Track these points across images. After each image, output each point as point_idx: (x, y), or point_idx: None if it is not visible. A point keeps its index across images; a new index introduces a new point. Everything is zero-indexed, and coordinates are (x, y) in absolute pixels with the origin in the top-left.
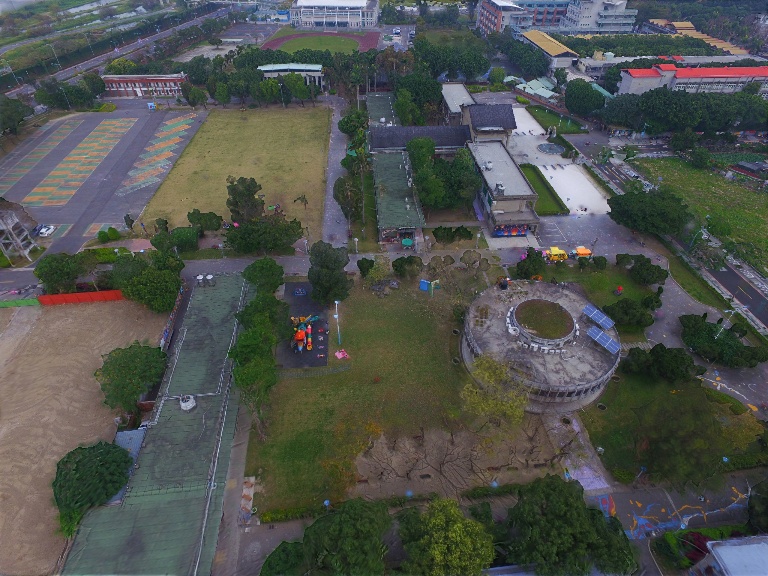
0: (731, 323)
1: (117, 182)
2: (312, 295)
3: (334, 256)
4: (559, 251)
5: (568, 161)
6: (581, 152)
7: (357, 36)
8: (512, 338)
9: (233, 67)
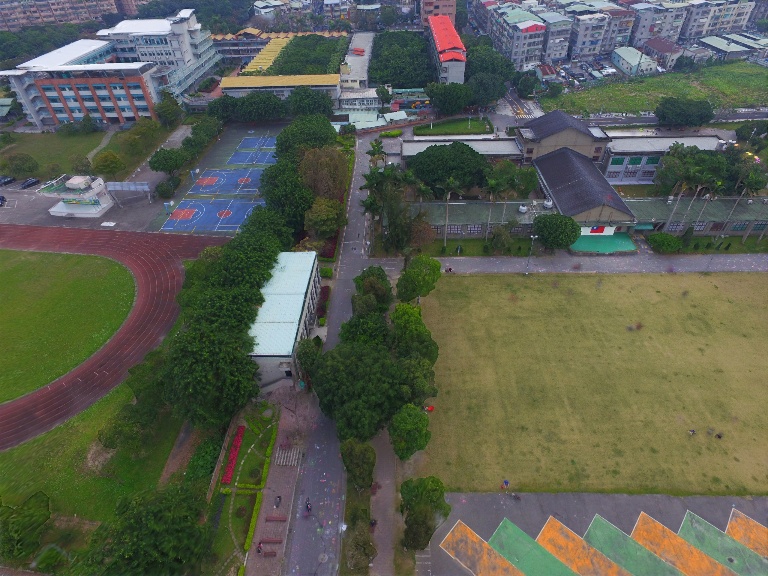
0: None
1: None
2: None
3: None
4: (750, 153)
5: None
6: None
7: None
8: None
9: None
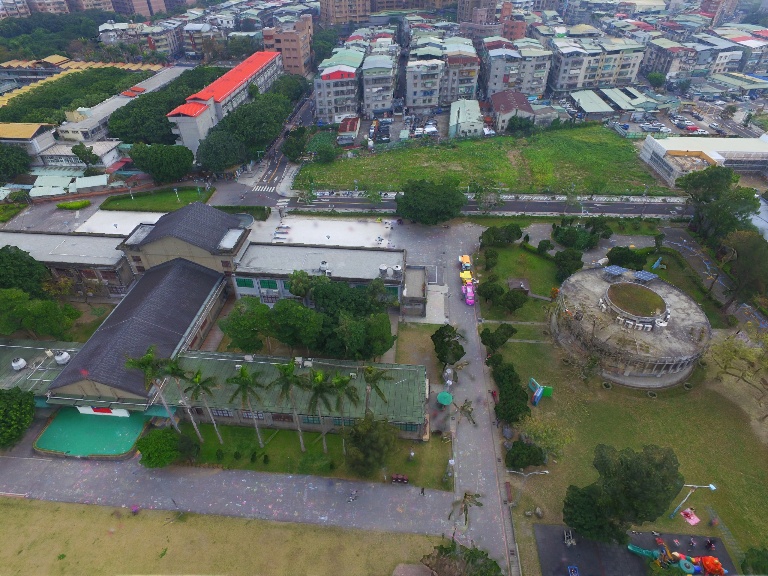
0: (549, 224)
1: None
2: None
3: None
4: (467, 273)
5: (274, 220)
6: None
7: None
8: None
9: None
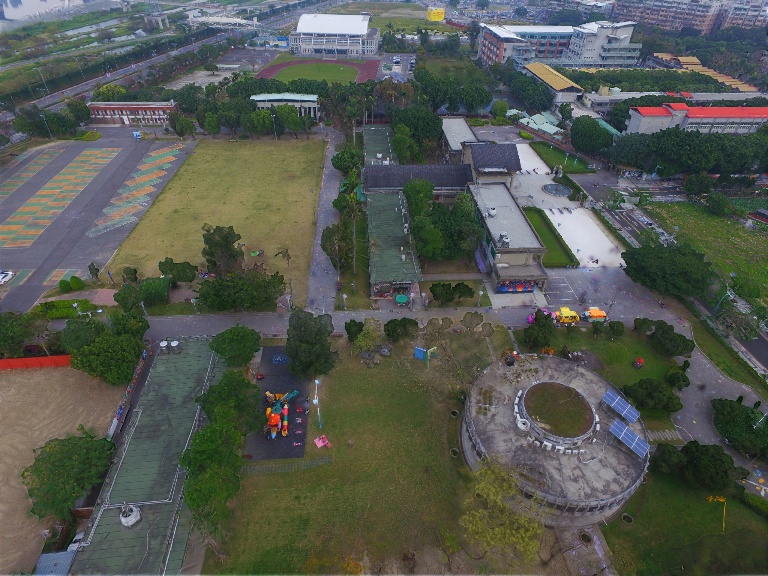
0: None
1: (90, 221)
2: (291, 367)
3: (315, 329)
4: (570, 312)
5: (576, 204)
6: (589, 194)
7: (356, 64)
8: (521, 433)
9: (227, 94)
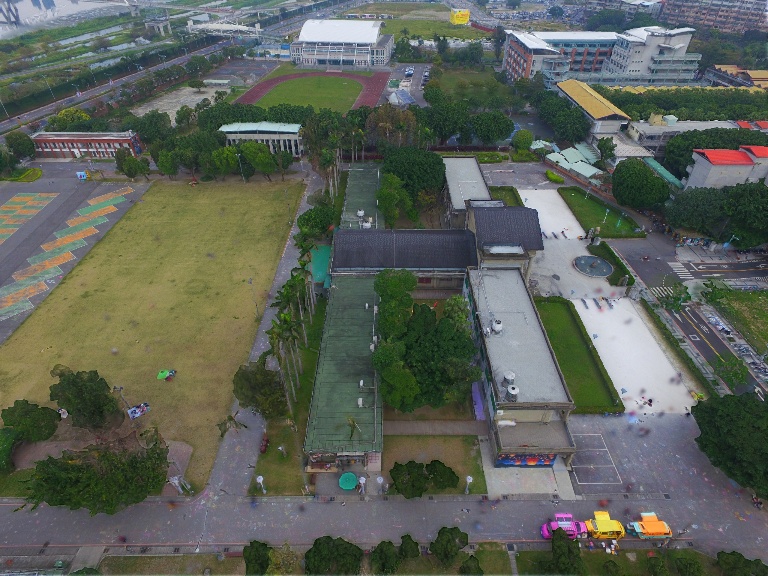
0: None
1: None
2: None
3: None
4: (610, 524)
5: (618, 292)
6: (637, 274)
7: (363, 77)
8: None
9: None
